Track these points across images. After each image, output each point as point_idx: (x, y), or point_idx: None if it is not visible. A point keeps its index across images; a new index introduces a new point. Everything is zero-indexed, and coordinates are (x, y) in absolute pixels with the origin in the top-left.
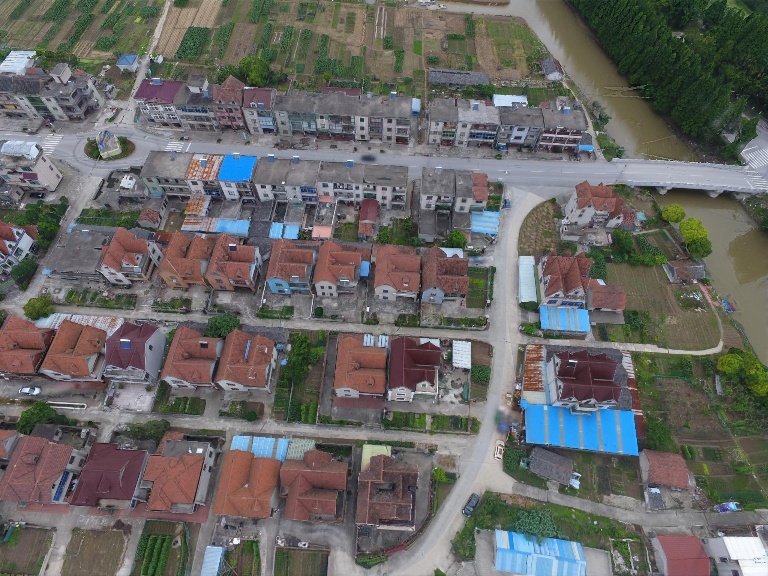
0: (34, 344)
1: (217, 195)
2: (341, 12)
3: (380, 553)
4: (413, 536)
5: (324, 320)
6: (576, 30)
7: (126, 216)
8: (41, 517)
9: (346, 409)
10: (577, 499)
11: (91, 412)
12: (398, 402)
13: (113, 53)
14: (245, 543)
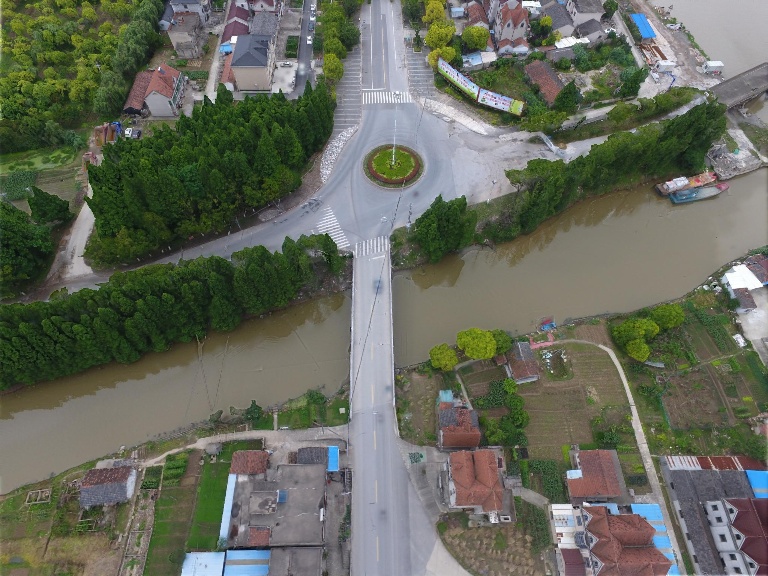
0: None
1: None
2: None
3: None
4: None
5: None
6: None
7: None
8: None
9: None
10: None
11: None
12: None
13: None
14: None
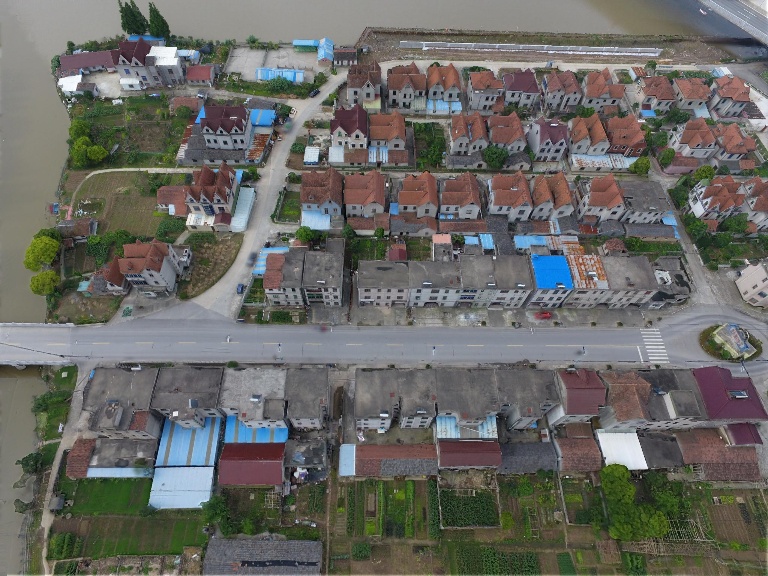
0: None
1: None
2: None
3: None
4: None
5: None
6: None
7: None
8: None
9: None
10: None
11: None
12: None
13: None
14: None
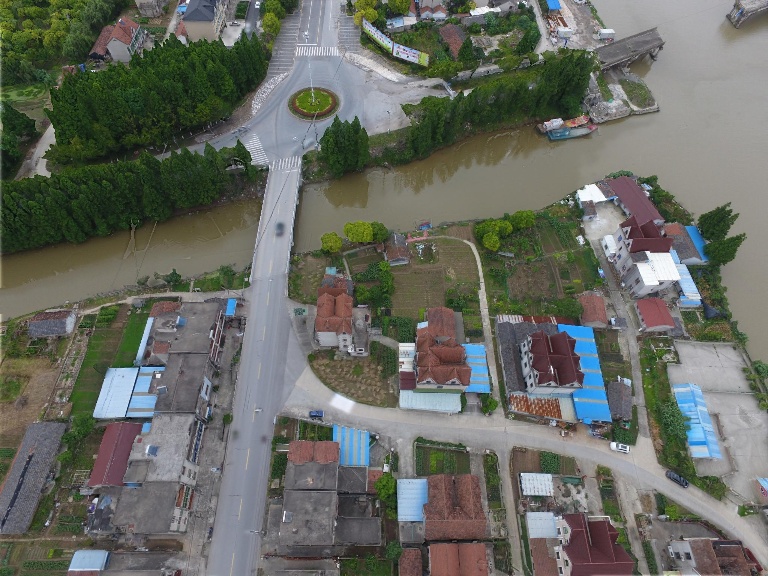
0: None
1: None
2: None
3: None
4: None
5: None
6: None
7: None
8: None
9: None
10: (635, 382)
11: None
12: None
13: None
14: None
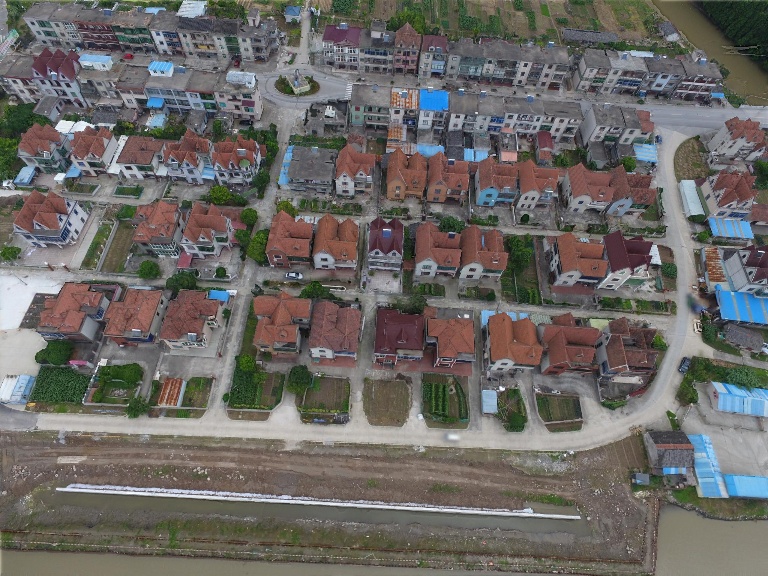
0: (304, 234)
1: (412, 124)
2: None
3: (622, 398)
4: (644, 387)
5: (526, 227)
6: (678, 1)
7: (330, 142)
8: (334, 370)
9: (563, 295)
10: (767, 363)
11: (350, 293)
12: (605, 290)
13: (280, 5)
14: (508, 391)
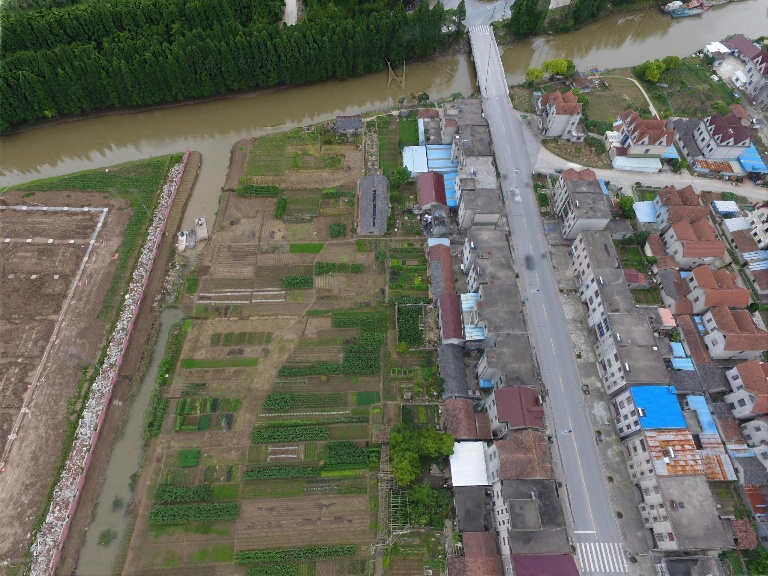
0: None
1: None
2: (209, 356)
3: None
4: None
5: None
6: (254, 103)
7: None
8: None
9: None
10: None
11: None
12: None
13: None
14: None
